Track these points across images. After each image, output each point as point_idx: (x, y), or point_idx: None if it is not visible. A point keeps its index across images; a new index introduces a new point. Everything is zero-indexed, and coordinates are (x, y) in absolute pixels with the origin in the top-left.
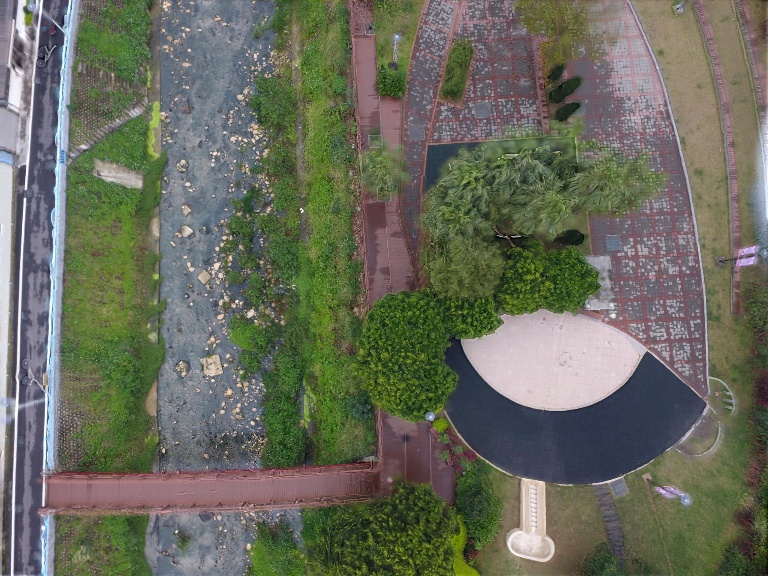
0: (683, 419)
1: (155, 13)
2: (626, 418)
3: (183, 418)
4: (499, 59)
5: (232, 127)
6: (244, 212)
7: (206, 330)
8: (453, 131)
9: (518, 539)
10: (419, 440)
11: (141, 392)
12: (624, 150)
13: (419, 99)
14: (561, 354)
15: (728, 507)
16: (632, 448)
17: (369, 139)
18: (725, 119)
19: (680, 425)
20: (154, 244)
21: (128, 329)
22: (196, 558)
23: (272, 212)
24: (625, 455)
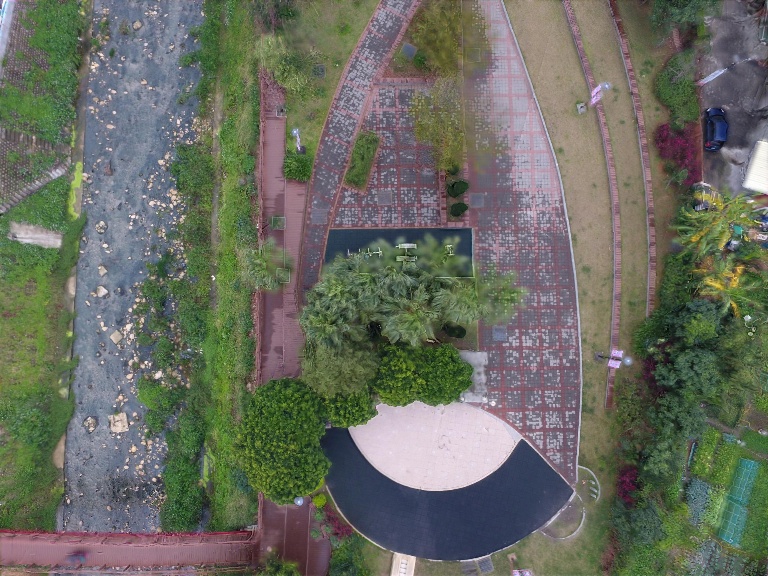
0: (550, 504)
1: (83, 73)
2: (497, 501)
3: (89, 471)
4: (405, 148)
5: (152, 191)
6: (158, 276)
7: (115, 388)
8: (354, 217)
9: None
10: (299, 513)
11: (49, 445)
12: (518, 243)
13: (324, 183)
14: (441, 437)
15: None
16: (500, 529)
17: (272, 221)
18: (616, 219)
19: (547, 510)
20: (69, 302)
21: (38, 385)
22: None
23: (185, 277)
24: (493, 535)
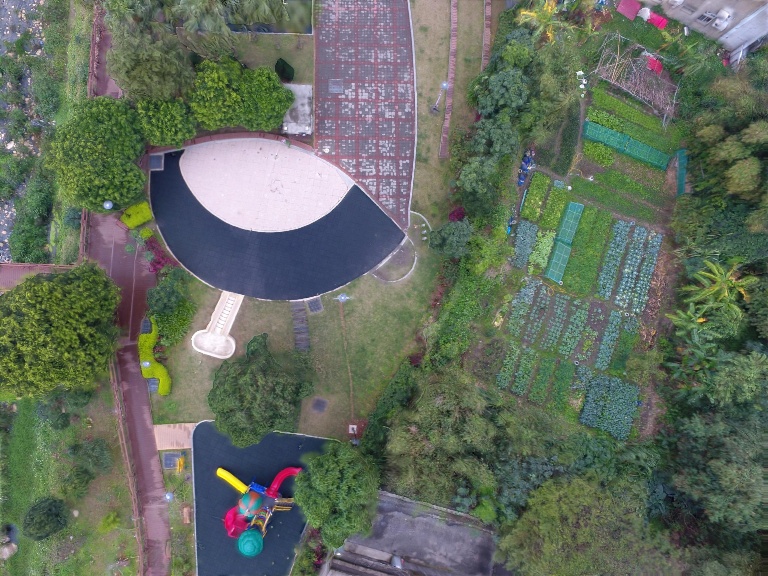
0: (381, 247)
1: None
2: (328, 243)
3: None
4: None
5: None
6: (16, 53)
7: None
8: None
9: (203, 338)
10: None
11: None
12: (357, 5)
13: None
14: (273, 182)
15: (413, 327)
16: (330, 270)
17: None
18: None
19: (378, 252)
20: None
21: None
22: None
23: (42, 54)
24: (323, 276)
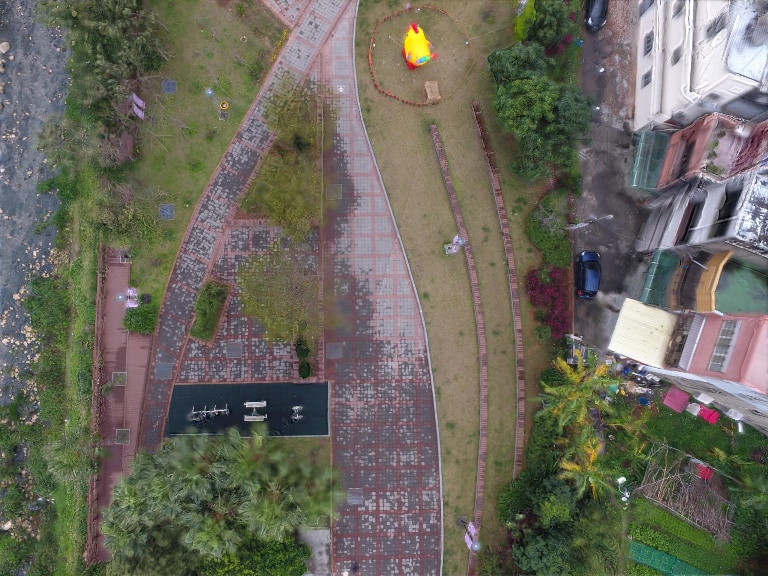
0: None
1: None
2: None
3: None
4: (258, 295)
5: (5, 328)
6: (10, 419)
7: None
8: (201, 371)
9: None
10: None
11: None
12: (377, 397)
13: (170, 335)
14: None
15: None
16: None
17: (113, 377)
18: (482, 372)
19: None
20: None
21: None
22: None
23: (38, 421)
24: None
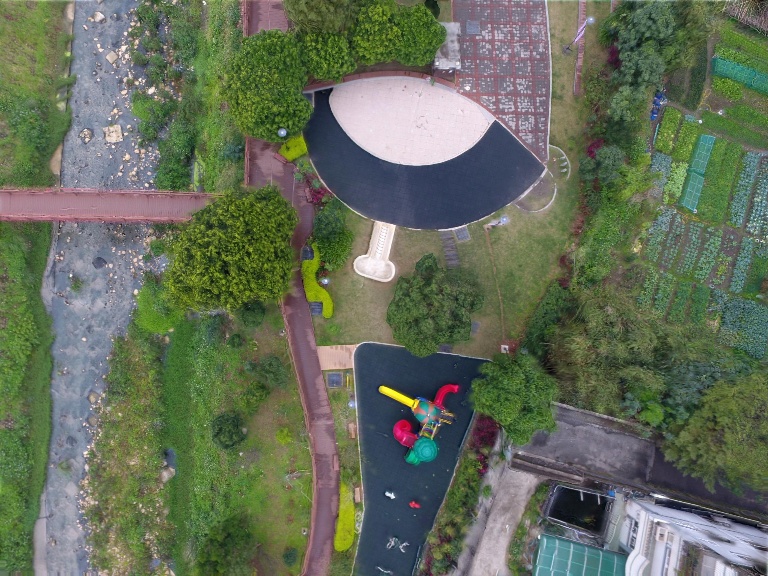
0: (523, 179)
1: None
2: (472, 175)
3: (84, 178)
4: None
5: None
6: (152, 3)
7: (110, 103)
8: None
9: (364, 263)
10: (284, 180)
11: (46, 151)
12: None
13: None
14: (418, 118)
15: (557, 254)
16: (476, 201)
17: None
18: None
19: (520, 184)
20: (68, 26)
21: (37, 93)
22: (88, 300)
23: (178, 4)
24: (469, 207)
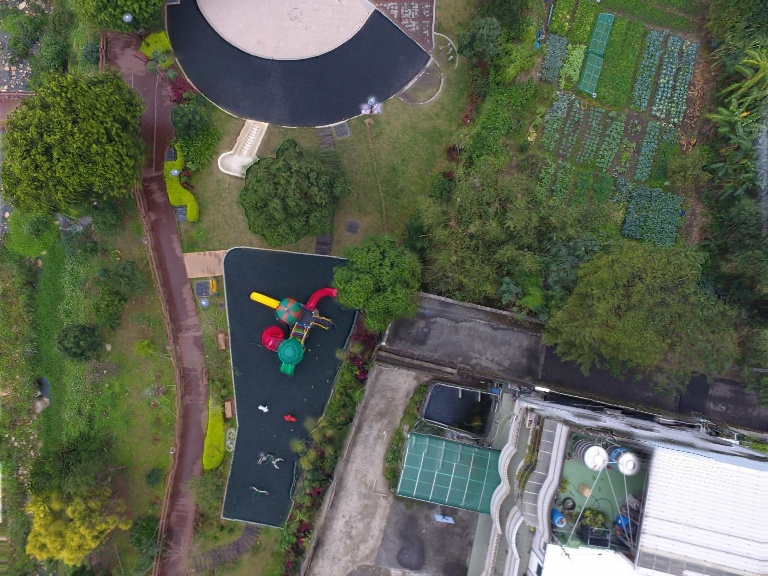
0: (406, 69)
1: None
2: (351, 68)
3: None
4: None
5: None
6: None
7: None
8: None
9: (229, 160)
10: (146, 79)
11: None
12: None
13: None
14: (292, 10)
15: (443, 147)
16: (355, 95)
17: None
18: None
19: (403, 75)
20: None
21: None
22: None
23: None
24: (348, 101)
